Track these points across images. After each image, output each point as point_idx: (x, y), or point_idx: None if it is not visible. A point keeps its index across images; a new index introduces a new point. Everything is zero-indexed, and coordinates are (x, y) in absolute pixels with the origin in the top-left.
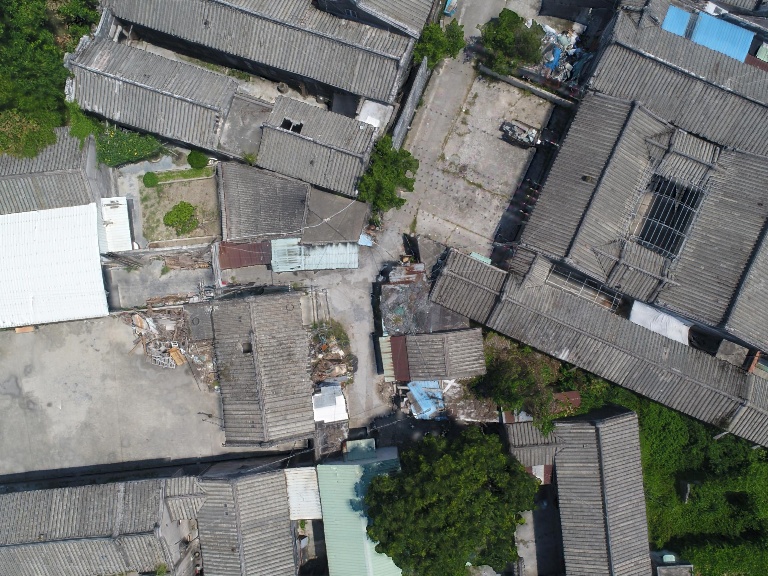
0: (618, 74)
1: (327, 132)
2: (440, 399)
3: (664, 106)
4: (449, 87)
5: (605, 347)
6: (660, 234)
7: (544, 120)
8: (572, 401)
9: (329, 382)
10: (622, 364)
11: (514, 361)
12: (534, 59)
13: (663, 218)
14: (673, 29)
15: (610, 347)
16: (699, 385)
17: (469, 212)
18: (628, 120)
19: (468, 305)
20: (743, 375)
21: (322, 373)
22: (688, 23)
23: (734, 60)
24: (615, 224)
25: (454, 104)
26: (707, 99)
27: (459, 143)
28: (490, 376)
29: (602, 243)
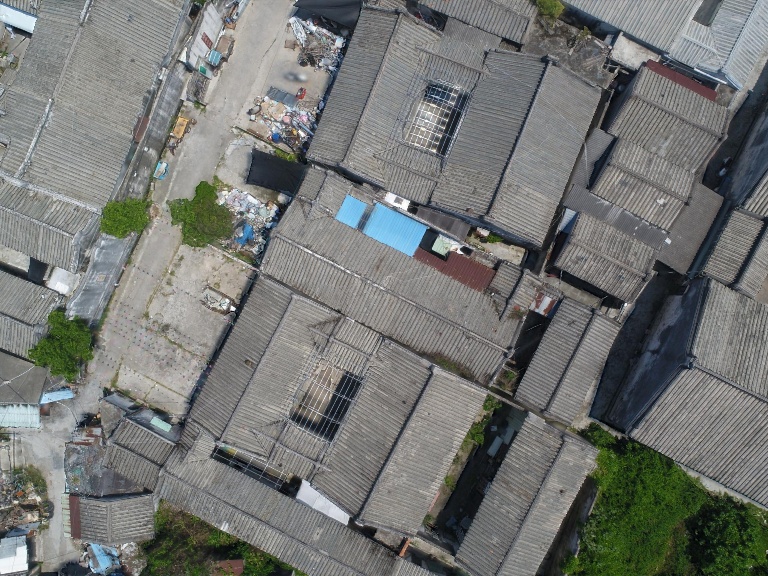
0: (286, 263)
1: (8, 300)
2: (116, 556)
3: (330, 295)
4: (157, 248)
5: (259, 525)
6: (314, 421)
7: (245, 286)
8: (234, 570)
9: (21, 528)
10: (276, 541)
11: (177, 530)
12: (224, 234)
13: (317, 406)
14: (346, 220)
15: (263, 525)
16: (345, 568)
17: (169, 370)
18: (285, 312)
19: (136, 473)
20: (392, 559)
21: (13, 520)
22: (363, 214)
23: (401, 254)
24: (278, 406)
25: (161, 265)
26: (367, 294)
27: (163, 303)
28: (160, 540)
29: (263, 424)
